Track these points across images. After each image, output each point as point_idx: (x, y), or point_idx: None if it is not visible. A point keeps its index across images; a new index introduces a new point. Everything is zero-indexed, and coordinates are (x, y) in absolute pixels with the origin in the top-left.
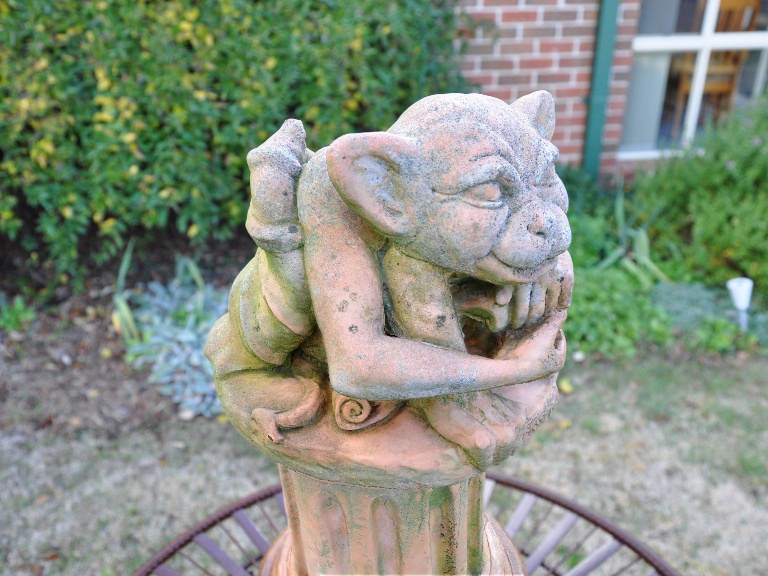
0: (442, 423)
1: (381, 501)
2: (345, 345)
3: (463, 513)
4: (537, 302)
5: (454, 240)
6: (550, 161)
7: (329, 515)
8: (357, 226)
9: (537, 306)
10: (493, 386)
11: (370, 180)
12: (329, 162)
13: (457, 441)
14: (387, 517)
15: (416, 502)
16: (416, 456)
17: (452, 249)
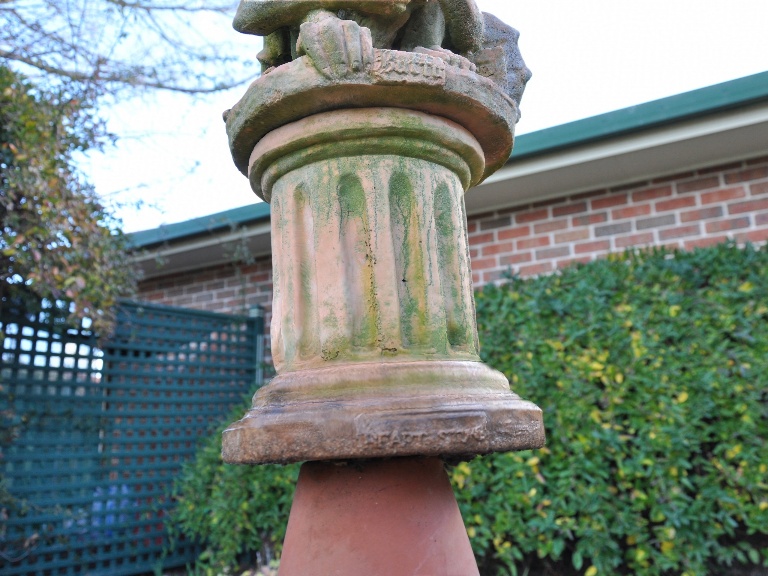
0: None
1: (306, 199)
2: None
3: (382, 224)
4: None
5: None
6: None
7: (281, 237)
8: None
9: None
10: None
11: None
12: None
13: None
14: (312, 220)
15: (324, 185)
16: None
17: None
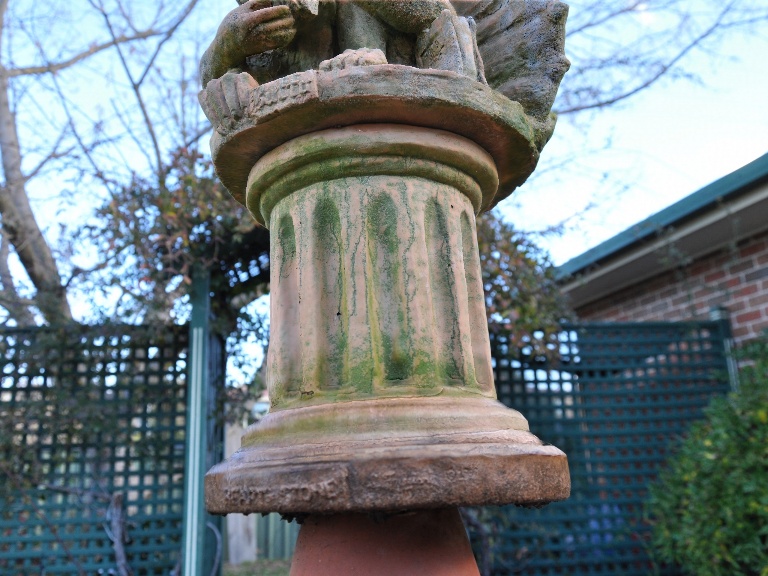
0: None
1: None
2: None
3: None
4: None
5: None
6: None
7: None
8: None
9: None
10: (213, 53)
11: None
12: None
13: None
14: None
15: None
16: None
17: None
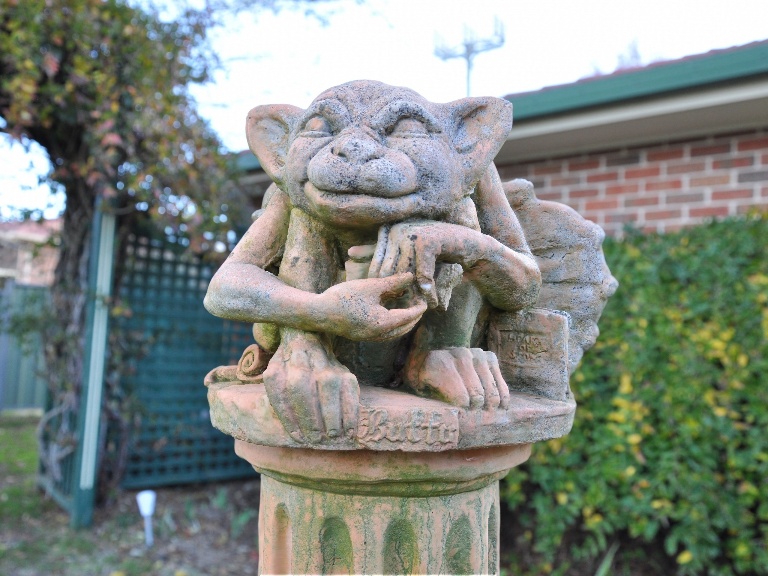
0: None
1: None
2: None
3: None
4: (386, 259)
5: None
6: (396, 110)
7: None
8: None
9: (385, 263)
10: (290, 312)
11: (272, 139)
12: None
13: None
14: None
15: (305, 524)
16: (244, 394)
17: None
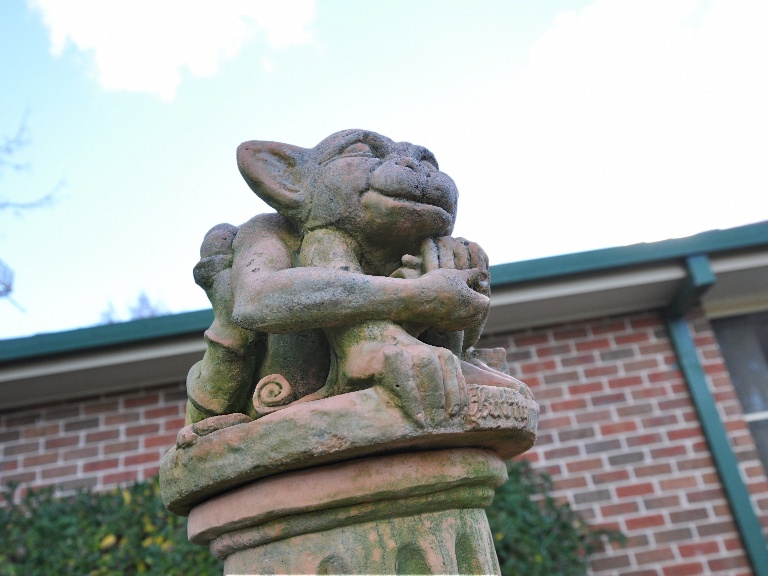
0: (355, 361)
1: None
2: (246, 281)
3: None
4: (445, 262)
5: (335, 181)
6: (421, 150)
7: None
8: (274, 230)
9: (446, 264)
10: (394, 296)
11: (272, 171)
12: (237, 158)
13: (370, 370)
14: None
15: (375, 564)
16: (329, 398)
17: (336, 190)
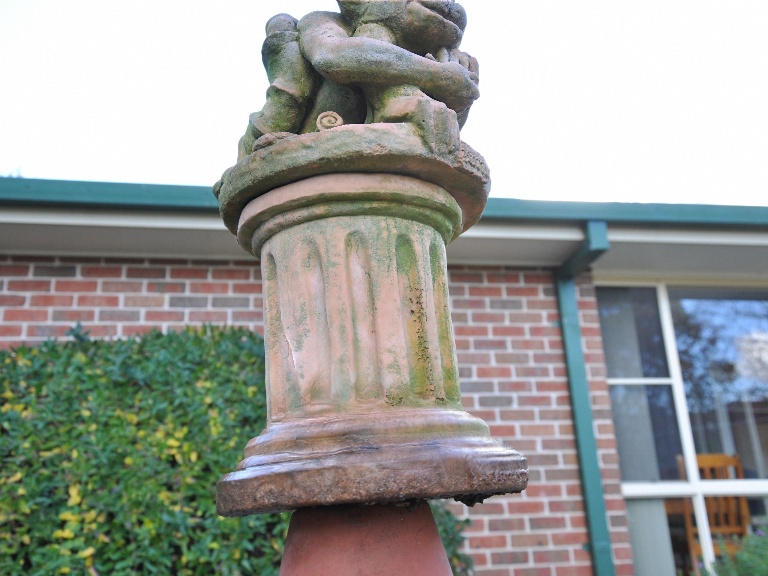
0: (394, 106)
1: (354, 247)
2: None
3: (429, 285)
4: None
5: None
6: None
7: (308, 276)
8: (334, 20)
9: None
10: (426, 69)
11: None
12: None
13: (406, 110)
14: (359, 268)
15: (383, 239)
16: None
17: None
